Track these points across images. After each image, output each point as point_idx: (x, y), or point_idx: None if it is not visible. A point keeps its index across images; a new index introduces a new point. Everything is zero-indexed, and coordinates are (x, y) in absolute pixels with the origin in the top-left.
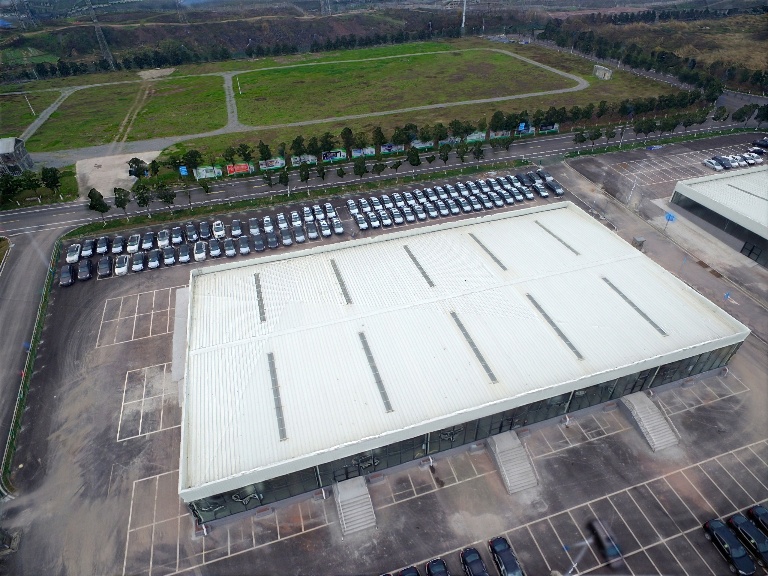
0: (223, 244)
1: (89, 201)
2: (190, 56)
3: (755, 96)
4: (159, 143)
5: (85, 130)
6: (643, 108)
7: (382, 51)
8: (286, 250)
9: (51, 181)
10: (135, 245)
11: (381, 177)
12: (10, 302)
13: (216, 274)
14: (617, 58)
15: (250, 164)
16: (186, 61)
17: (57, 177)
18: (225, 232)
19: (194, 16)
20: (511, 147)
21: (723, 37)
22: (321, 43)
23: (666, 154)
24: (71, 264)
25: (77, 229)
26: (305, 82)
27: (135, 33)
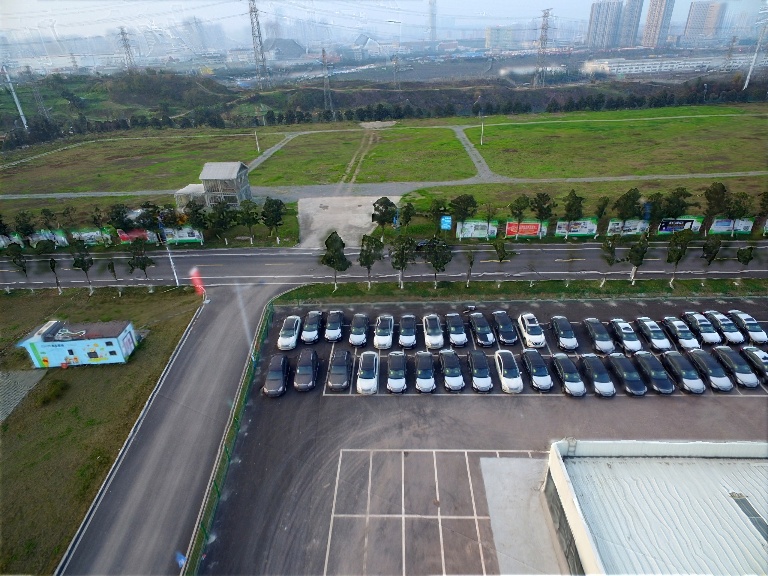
0: (554, 365)
1: (312, 250)
2: (413, 111)
3: None
4: (396, 188)
5: (309, 168)
6: None
7: (644, 112)
8: (695, 404)
9: (272, 217)
10: (387, 335)
11: None
12: (180, 411)
13: (611, 464)
14: None
15: (544, 224)
16: (408, 115)
17: (280, 213)
18: (545, 338)
19: (407, 85)
20: None
21: None
22: (561, 103)
23: None
24: (284, 352)
25: (296, 290)
26: (561, 137)
27: (353, 96)
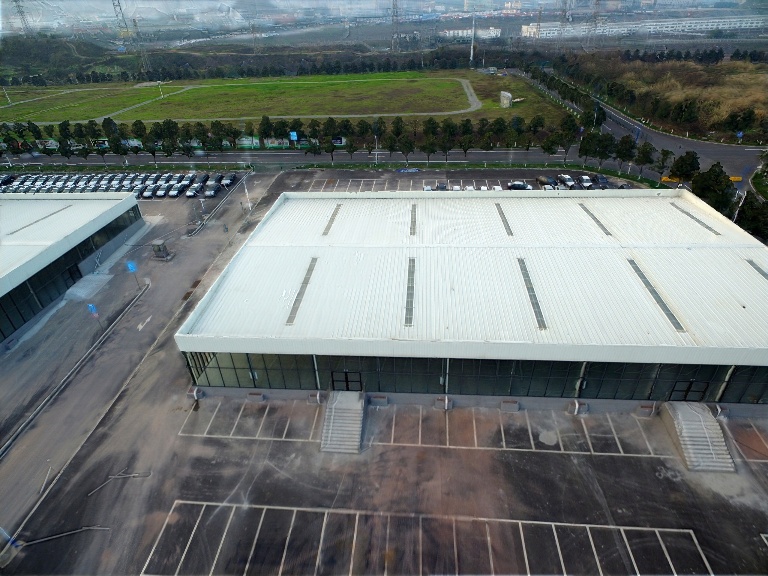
0: None
1: None
2: (191, 73)
3: (674, 136)
4: None
5: (8, 113)
6: (450, 130)
7: (352, 76)
8: None
9: None
10: None
11: (104, 164)
12: None
13: None
14: (557, 88)
15: None
16: (185, 77)
17: None
18: None
19: (271, 50)
20: (268, 155)
21: (761, 76)
22: (307, 68)
23: (405, 177)
24: None
25: None
26: (228, 94)
27: (204, 59)
